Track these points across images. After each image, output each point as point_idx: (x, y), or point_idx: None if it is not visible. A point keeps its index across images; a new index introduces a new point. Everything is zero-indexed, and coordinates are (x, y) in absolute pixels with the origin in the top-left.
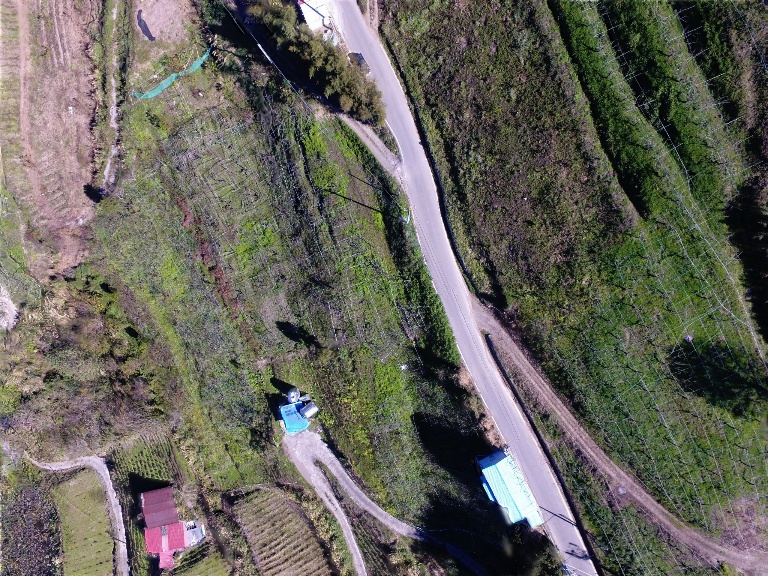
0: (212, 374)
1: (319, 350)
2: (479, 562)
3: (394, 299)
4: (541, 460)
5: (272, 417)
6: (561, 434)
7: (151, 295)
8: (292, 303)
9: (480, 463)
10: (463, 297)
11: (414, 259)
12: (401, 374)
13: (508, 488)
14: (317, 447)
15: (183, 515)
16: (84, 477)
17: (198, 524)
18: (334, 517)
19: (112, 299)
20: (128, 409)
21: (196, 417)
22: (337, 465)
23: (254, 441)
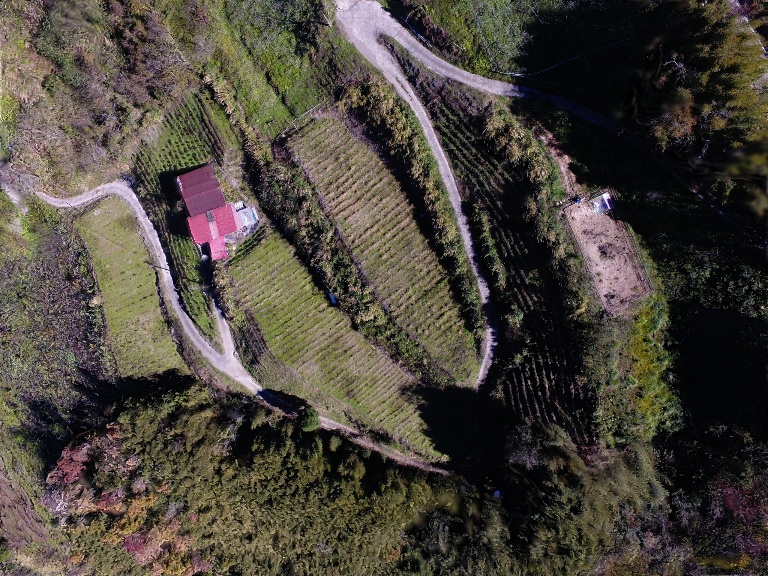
0: None
1: None
2: (595, 108)
3: None
4: None
5: None
6: None
7: None
8: None
9: None
10: None
11: None
12: None
13: None
14: (378, 18)
15: (229, 195)
16: (109, 204)
17: (248, 206)
18: (410, 107)
19: None
20: (145, 58)
21: (226, 45)
22: (405, 35)
23: (300, 42)
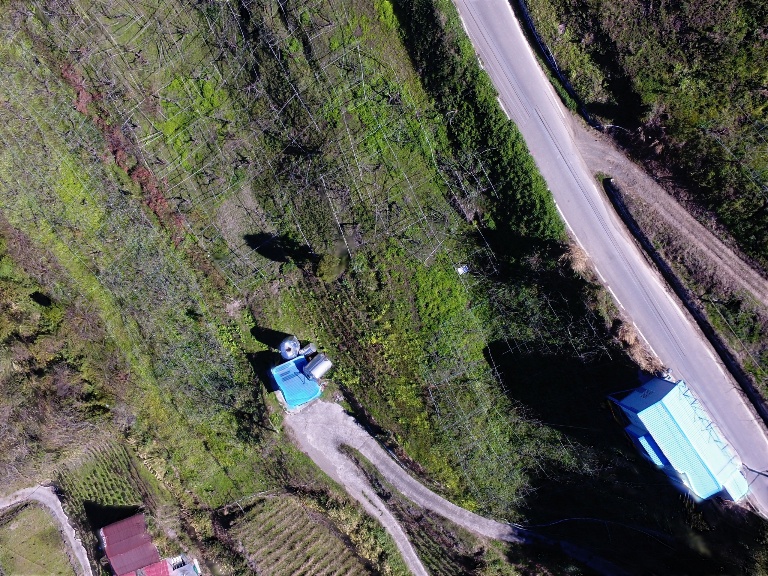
0: (164, 339)
1: (319, 267)
2: (617, 563)
3: (432, 153)
4: (725, 384)
5: (262, 388)
6: (765, 331)
7: (55, 235)
8: (264, 200)
9: (625, 404)
10: (556, 119)
11: (461, 63)
12: (459, 282)
13: (689, 439)
14: (339, 424)
15: (164, 550)
16: (28, 516)
17: (188, 559)
18: (380, 525)
19: (1, 253)
20: (55, 412)
21: (154, 408)
22: (374, 447)
23: (243, 430)
